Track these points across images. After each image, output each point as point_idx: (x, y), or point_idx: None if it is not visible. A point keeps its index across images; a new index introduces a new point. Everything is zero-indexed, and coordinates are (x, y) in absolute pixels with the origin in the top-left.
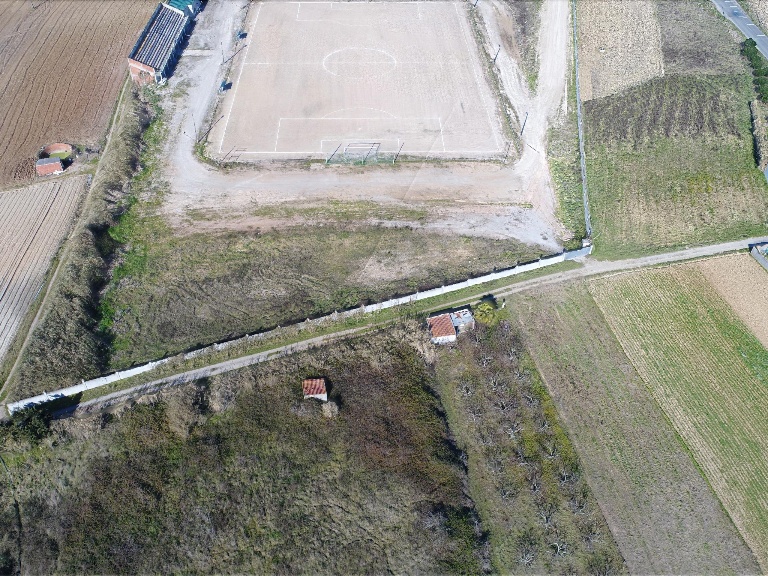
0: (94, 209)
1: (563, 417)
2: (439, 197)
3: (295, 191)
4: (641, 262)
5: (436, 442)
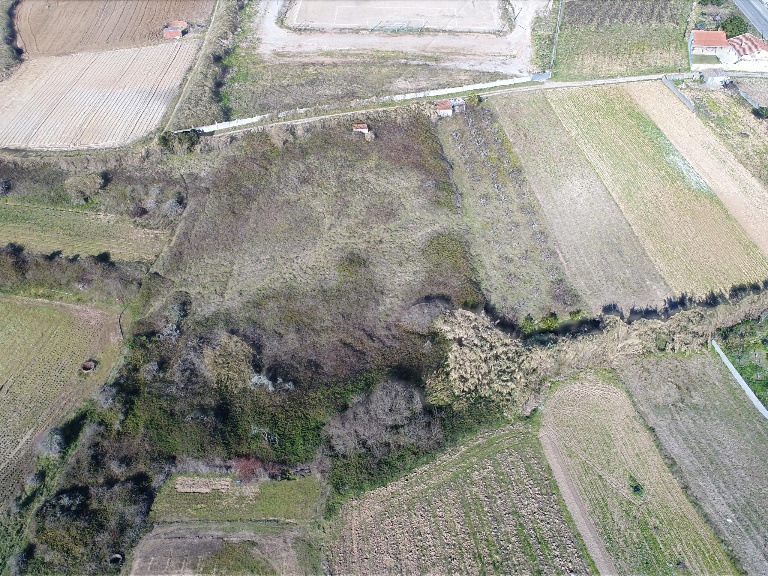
0: (210, 50)
1: (516, 150)
2: (450, 50)
3: (349, 44)
4: (584, 83)
5: (434, 153)
